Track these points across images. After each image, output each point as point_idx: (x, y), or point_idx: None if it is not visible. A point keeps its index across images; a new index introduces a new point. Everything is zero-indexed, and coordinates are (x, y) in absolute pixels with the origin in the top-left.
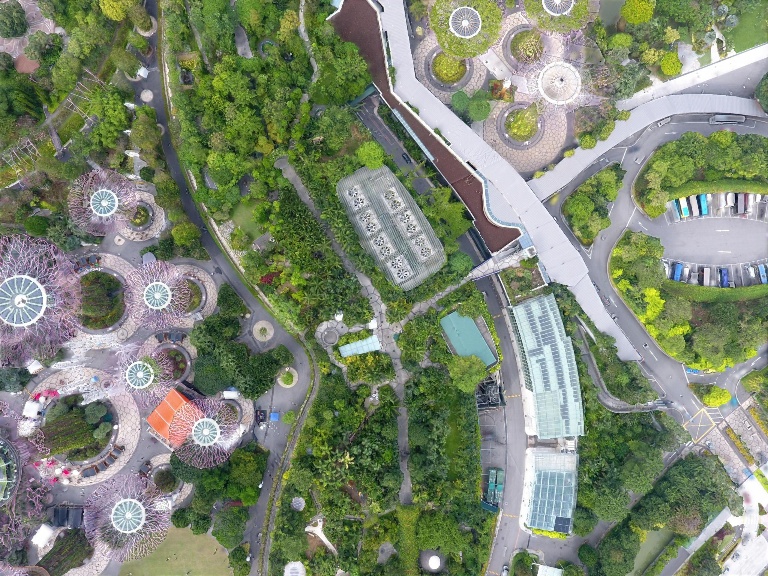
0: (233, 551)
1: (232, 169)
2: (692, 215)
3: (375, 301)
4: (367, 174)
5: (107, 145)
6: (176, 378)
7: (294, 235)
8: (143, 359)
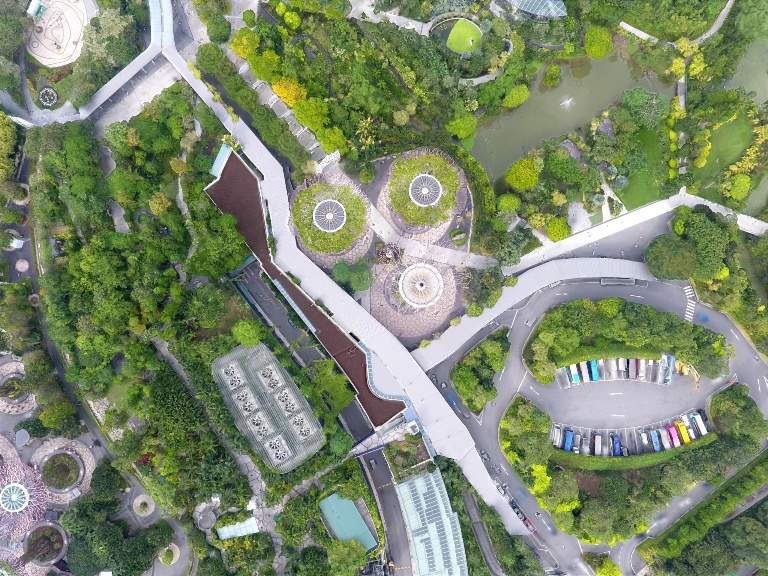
0: None
1: (101, 352)
2: (583, 381)
3: (256, 478)
4: (243, 352)
5: None
6: (52, 558)
7: (167, 418)
8: None
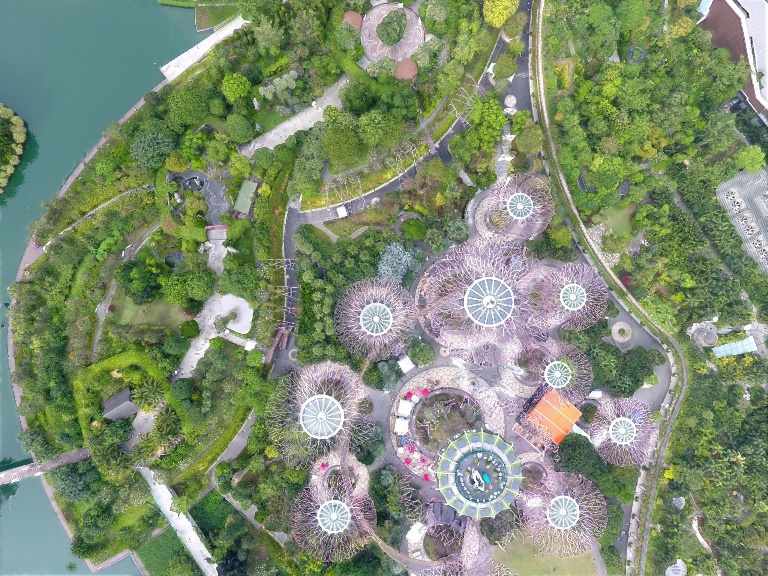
0: (609, 548)
1: (619, 173)
2: None
3: None
4: (745, 178)
5: (486, 149)
6: None
7: (676, 238)
8: (562, 359)
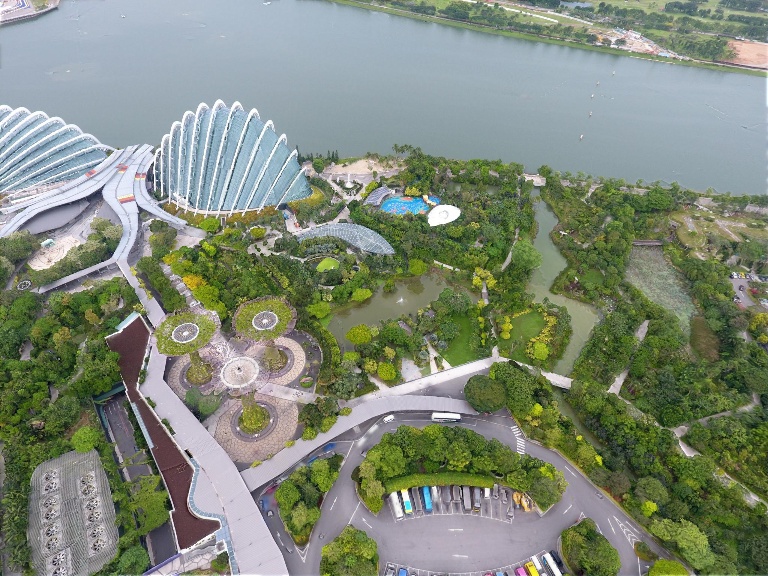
0: None
1: None
2: (415, 509)
3: None
4: (73, 458)
5: None
6: None
7: None
8: None
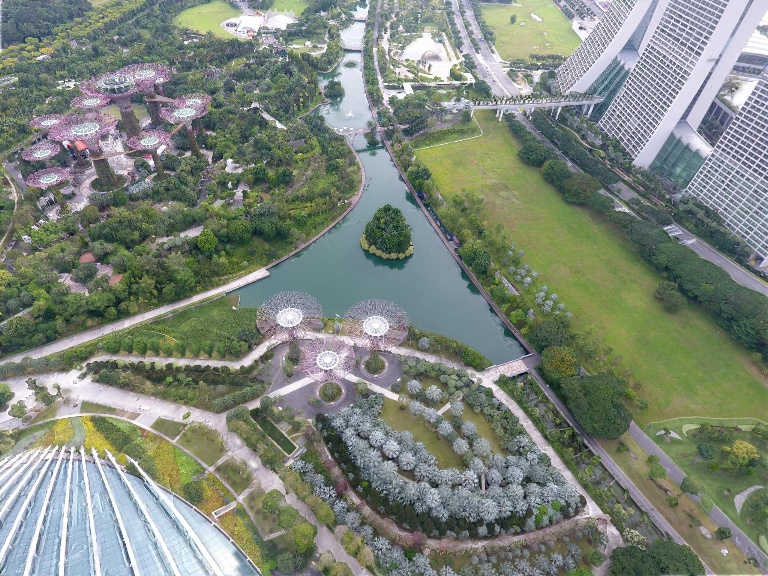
0: None
1: None
2: None
3: None
4: None
5: None
6: None
7: None
8: None
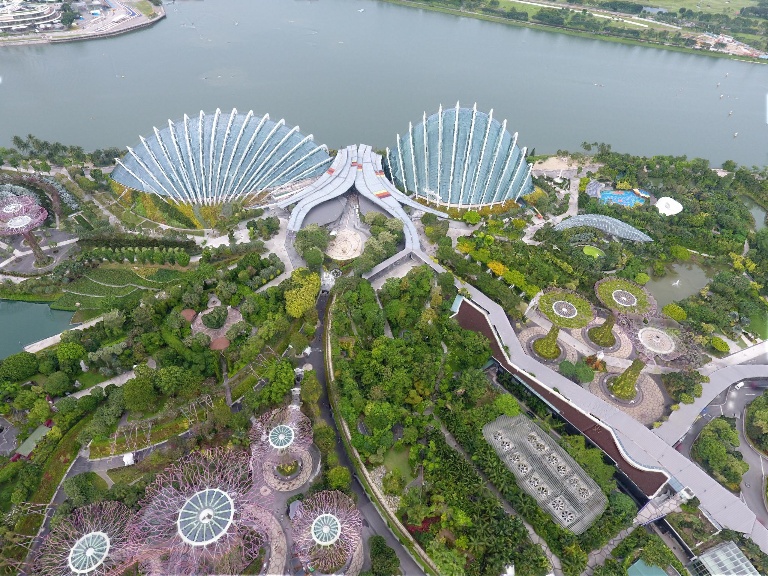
0: None
1: (388, 415)
2: None
3: None
4: (507, 421)
5: (275, 400)
6: None
7: (450, 475)
8: None
